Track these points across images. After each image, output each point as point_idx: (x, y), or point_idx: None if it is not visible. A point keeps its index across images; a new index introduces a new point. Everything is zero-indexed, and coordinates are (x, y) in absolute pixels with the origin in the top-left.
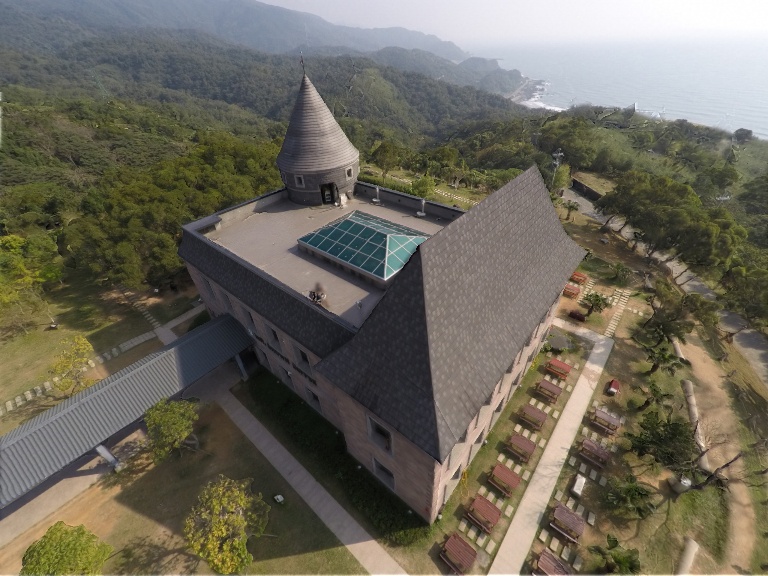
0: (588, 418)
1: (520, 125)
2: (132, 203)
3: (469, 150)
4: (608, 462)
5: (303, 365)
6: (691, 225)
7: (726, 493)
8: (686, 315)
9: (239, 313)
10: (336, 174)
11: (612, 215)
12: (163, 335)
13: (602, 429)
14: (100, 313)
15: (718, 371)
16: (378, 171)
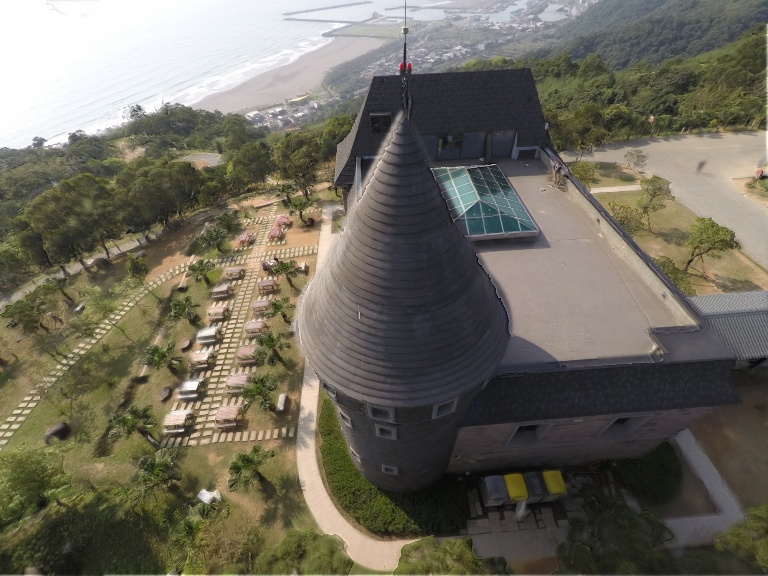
0: None
1: None
2: None
3: None
4: None
5: None
6: (177, 170)
7: None
8: None
9: None
10: None
11: None
12: (730, 506)
13: None
14: None
15: None
16: None
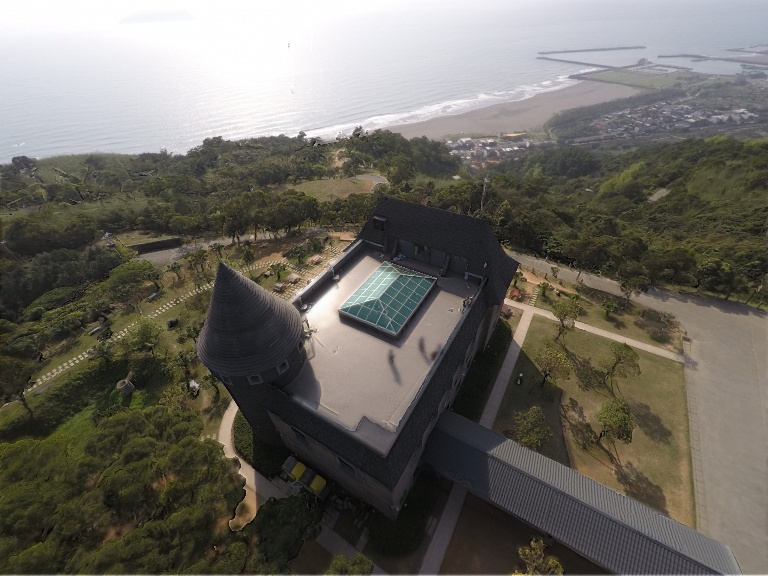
0: None
1: None
2: None
3: None
4: None
5: None
6: (303, 202)
7: None
8: None
9: None
10: None
11: None
12: None
13: None
14: None
15: None
16: None
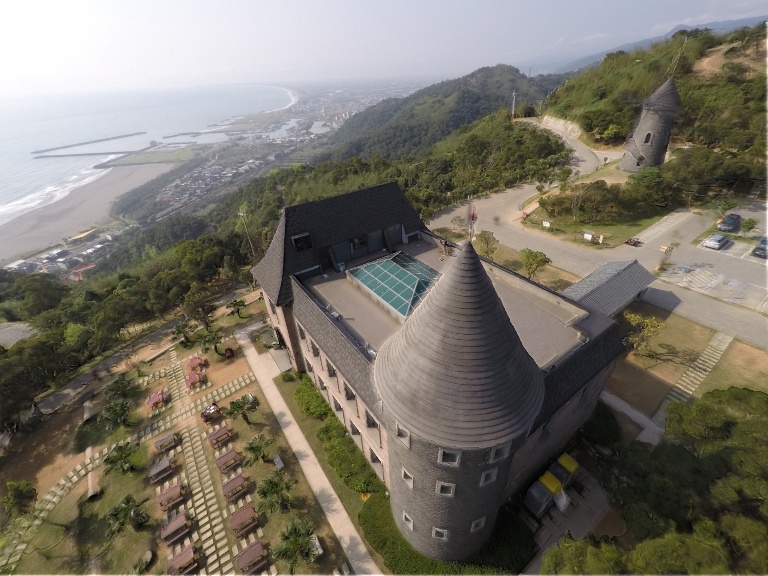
0: None
1: None
2: None
3: None
4: None
5: None
6: (30, 353)
7: None
8: None
9: None
10: None
11: None
12: (644, 419)
13: None
14: None
15: None
16: None
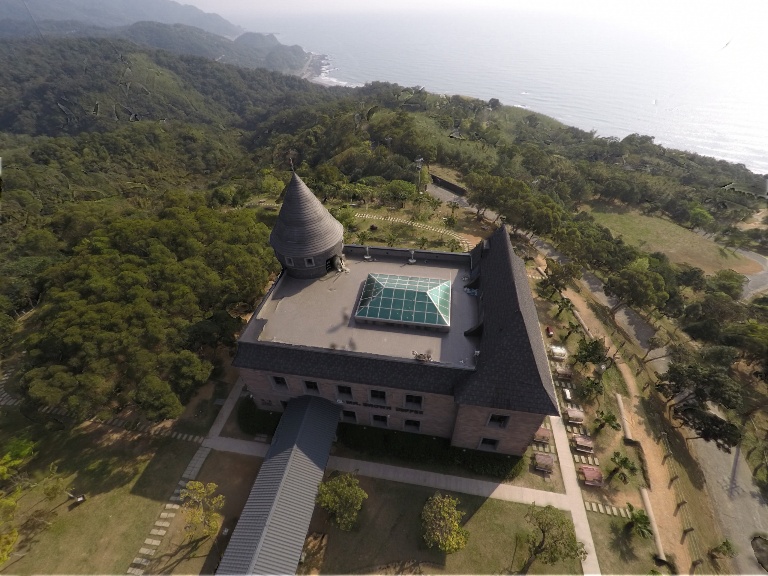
0: (549, 355)
1: (351, 120)
2: (107, 332)
3: (307, 147)
4: (571, 375)
5: (409, 405)
6: (538, 212)
7: (617, 364)
8: (566, 275)
9: (327, 391)
10: (337, 247)
11: (482, 208)
12: (217, 445)
13: (559, 358)
14: (122, 459)
15: (582, 299)
16: (277, 204)
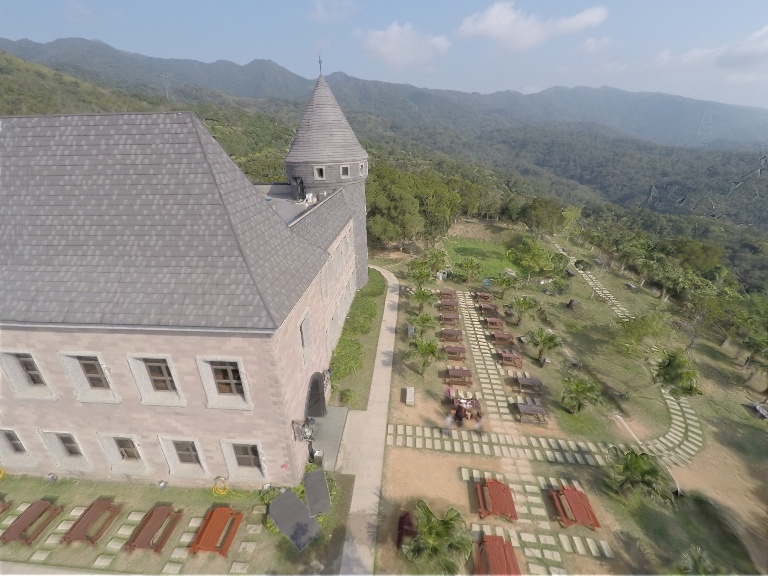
0: None
1: None
2: None
3: None
4: None
5: None
6: None
7: None
8: None
9: None
10: (304, 169)
11: None
12: None
13: None
14: None
15: None
16: (555, 241)
